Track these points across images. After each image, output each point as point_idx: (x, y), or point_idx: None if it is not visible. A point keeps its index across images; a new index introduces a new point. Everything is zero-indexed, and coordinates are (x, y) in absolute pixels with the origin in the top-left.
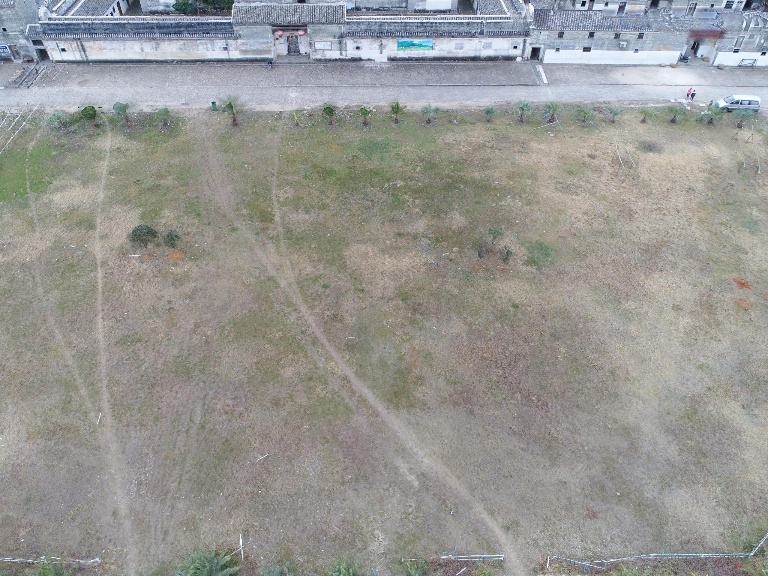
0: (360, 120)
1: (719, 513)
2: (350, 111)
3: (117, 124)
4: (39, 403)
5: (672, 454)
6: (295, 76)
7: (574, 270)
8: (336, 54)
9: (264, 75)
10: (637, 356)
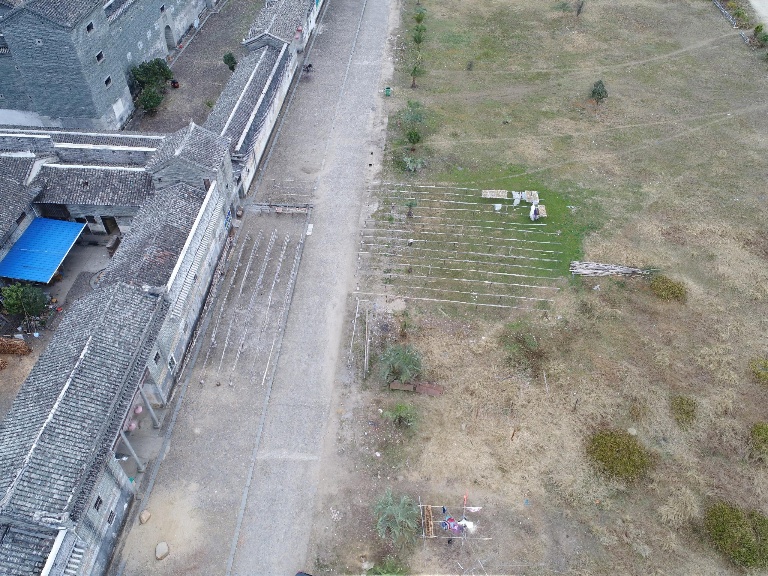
0: (413, 41)
1: (697, 2)
2: (398, 44)
3: (408, 141)
4: (732, 133)
5: (676, 4)
6: (331, 61)
7: (572, 4)
8: (307, 36)
9: (324, 74)
10: (626, 1)
